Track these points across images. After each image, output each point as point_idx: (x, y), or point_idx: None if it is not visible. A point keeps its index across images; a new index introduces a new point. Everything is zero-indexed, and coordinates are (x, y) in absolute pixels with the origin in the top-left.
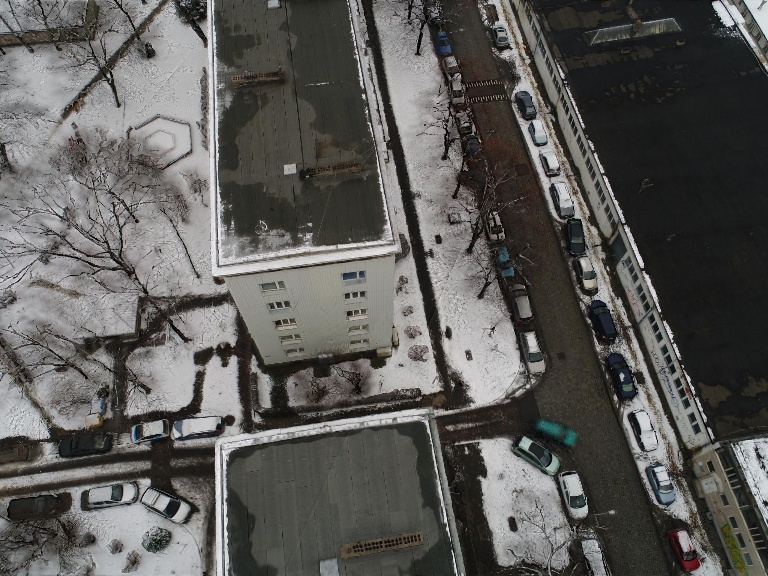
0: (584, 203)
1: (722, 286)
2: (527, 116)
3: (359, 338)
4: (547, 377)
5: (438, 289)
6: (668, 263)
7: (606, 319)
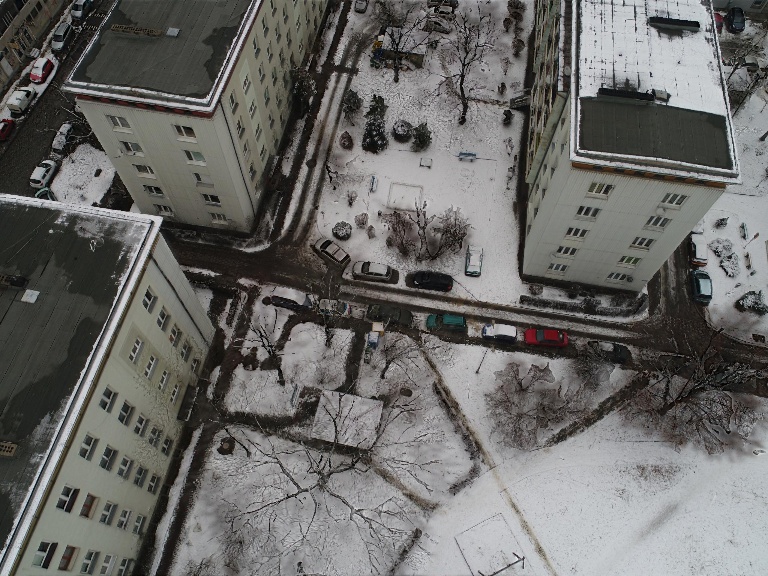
0: None
1: None
2: None
3: None
4: None
5: None
6: None
7: None
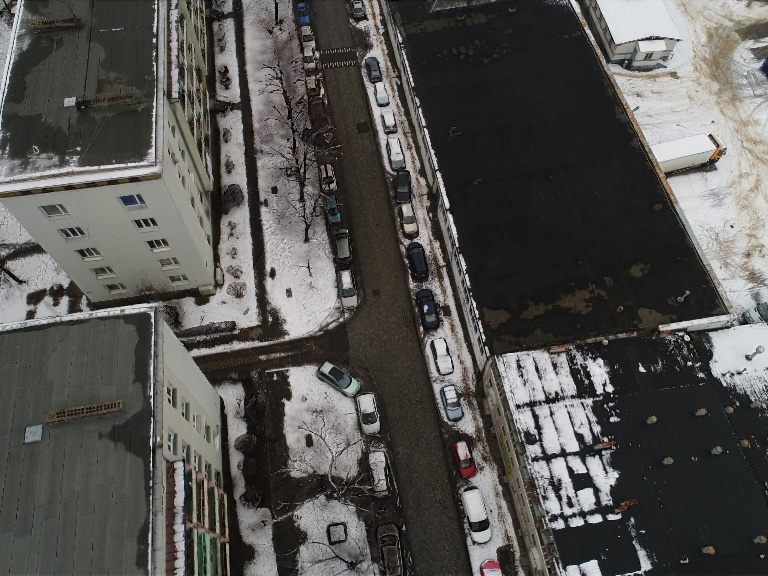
0: (417, 157)
1: (517, 223)
2: (373, 79)
3: (175, 274)
4: (360, 311)
5: (268, 234)
6: (472, 204)
7: (418, 258)
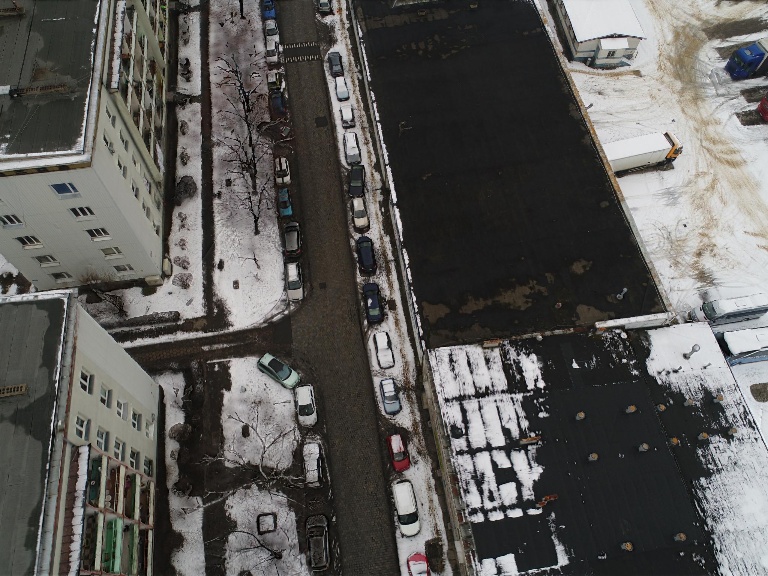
0: (373, 152)
1: (463, 218)
2: (334, 74)
3: (119, 263)
4: (305, 304)
5: (219, 226)
6: (419, 199)
7: (366, 252)
